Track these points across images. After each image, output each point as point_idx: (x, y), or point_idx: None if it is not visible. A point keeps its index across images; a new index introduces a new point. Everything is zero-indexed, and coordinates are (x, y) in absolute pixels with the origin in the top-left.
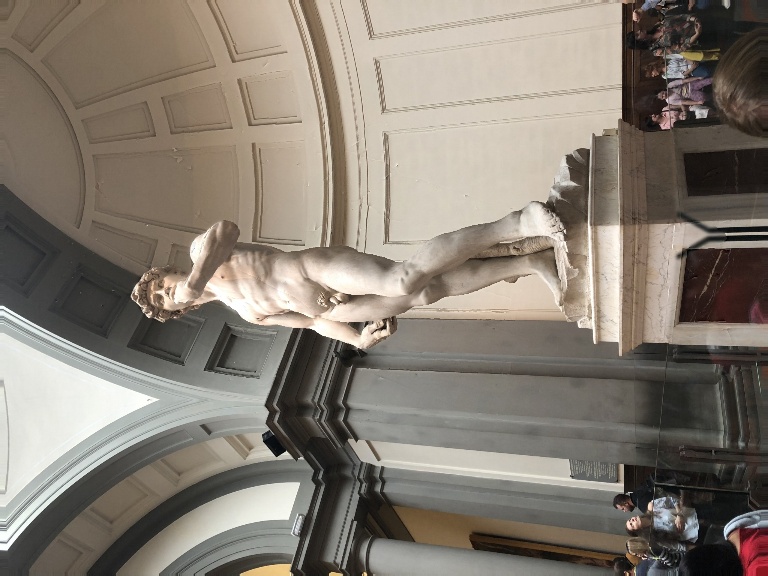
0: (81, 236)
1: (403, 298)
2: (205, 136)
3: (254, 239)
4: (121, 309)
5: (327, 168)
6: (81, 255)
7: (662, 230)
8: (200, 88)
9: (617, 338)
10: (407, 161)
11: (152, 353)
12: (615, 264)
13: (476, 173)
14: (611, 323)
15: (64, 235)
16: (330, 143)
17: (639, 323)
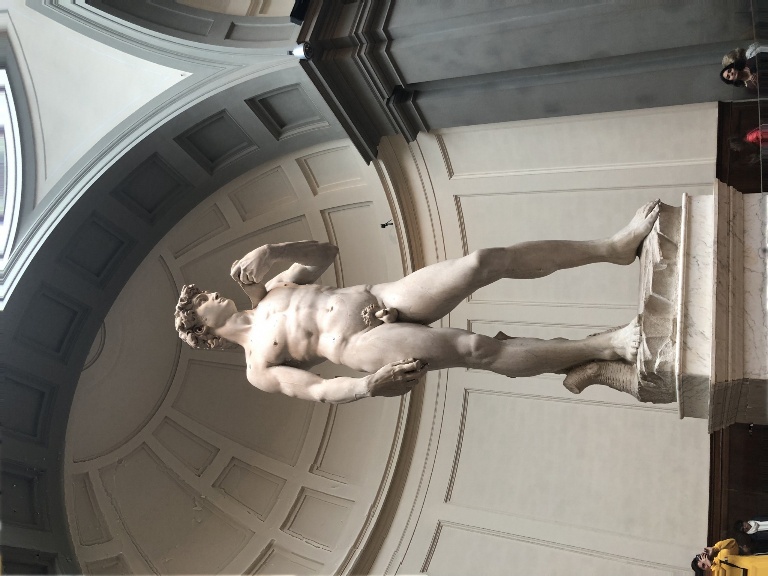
0: None
1: (453, 330)
2: (238, 506)
3: None
4: (25, 527)
5: None
6: (54, 469)
7: (757, 200)
8: (266, 474)
9: (708, 367)
10: None
11: (1, 574)
12: (708, 243)
13: None
14: (701, 338)
15: (64, 445)
16: (350, 569)
17: (738, 335)
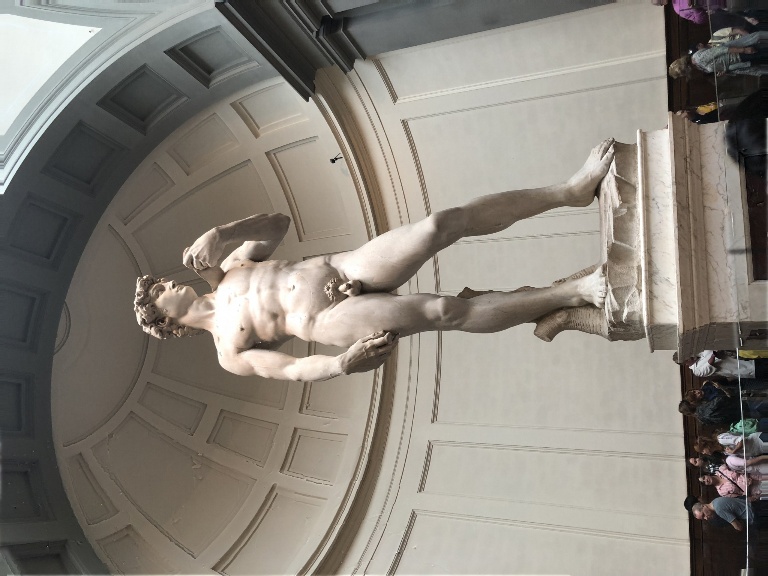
0: (60, 450)
1: (419, 297)
2: (235, 457)
3: (214, 569)
4: (29, 522)
5: (339, 518)
6: (46, 458)
7: (713, 131)
8: (258, 421)
9: (675, 315)
10: (428, 546)
11: (15, 574)
12: (667, 183)
13: (506, 573)
14: (666, 285)
15: (50, 433)
16: (353, 501)
17: (702, 278)
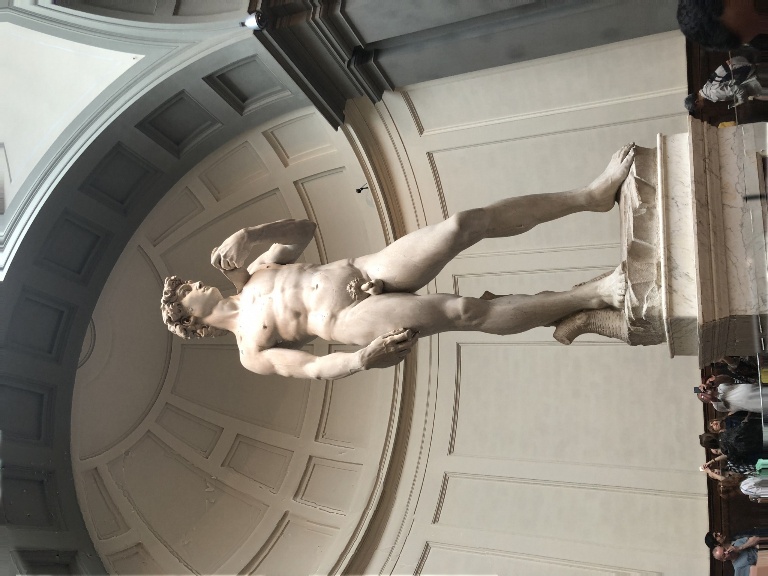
0: None
1: (440, 296)
2: (249, 482)
3: None
4: (41, 530)
5: (351, 546)
6: (62, 469)
7: (731, 134)
8: (273, 448)
9: (695, 308)
10: None
11: None
12: (686, 183)
13: None
14: (686, 280)
15: (68, 445)
16: (366, 530)
17: (721, 273)
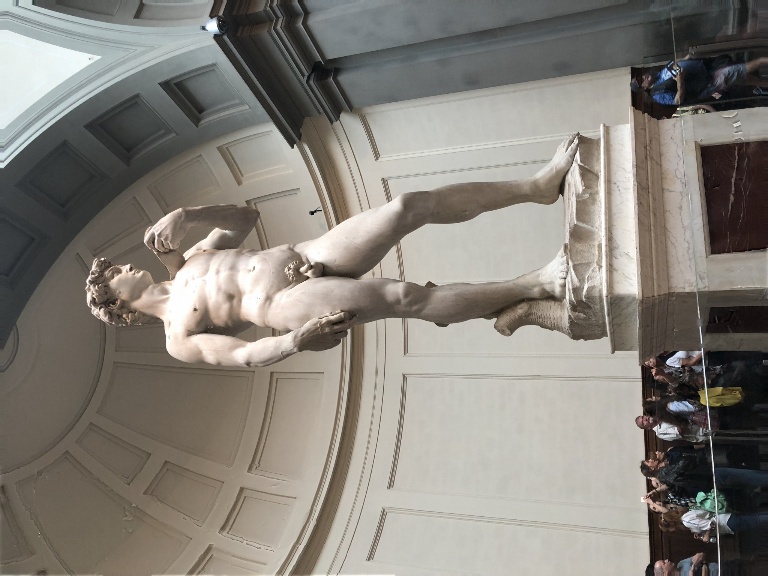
0: None
1: (380, 279)
2: (172, 512)
3: None
4: None
5: None
6: None
7: (671, 125)
8: (202, 478)
9: (635, 286)
10: None
11: None
12: (628, 169)
13: None
14: (626, 259)
15: None
16: (294, 565)
17: (661, 252)
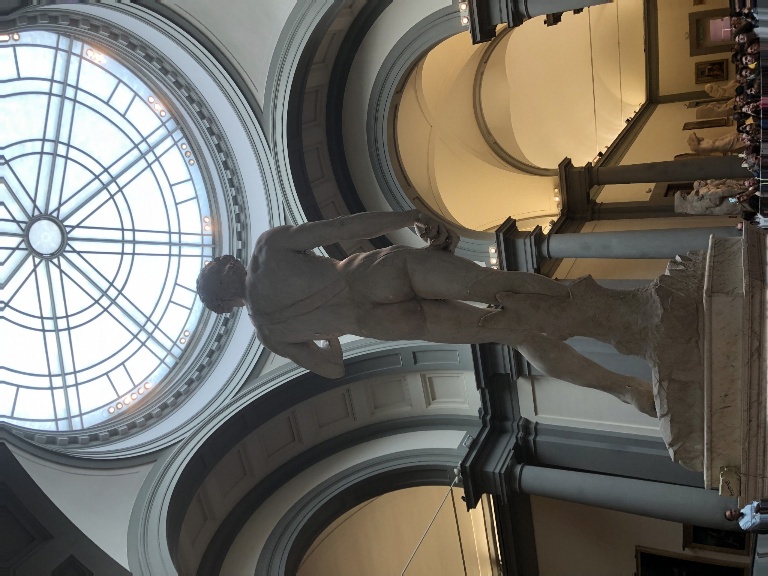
0: None
1: None
2: None
3: None
4: None
5: None
6: None
7: None
8: None
9: None
10: None
11: None
12: None
13: None
14: None
15: None
16: None
17: None
